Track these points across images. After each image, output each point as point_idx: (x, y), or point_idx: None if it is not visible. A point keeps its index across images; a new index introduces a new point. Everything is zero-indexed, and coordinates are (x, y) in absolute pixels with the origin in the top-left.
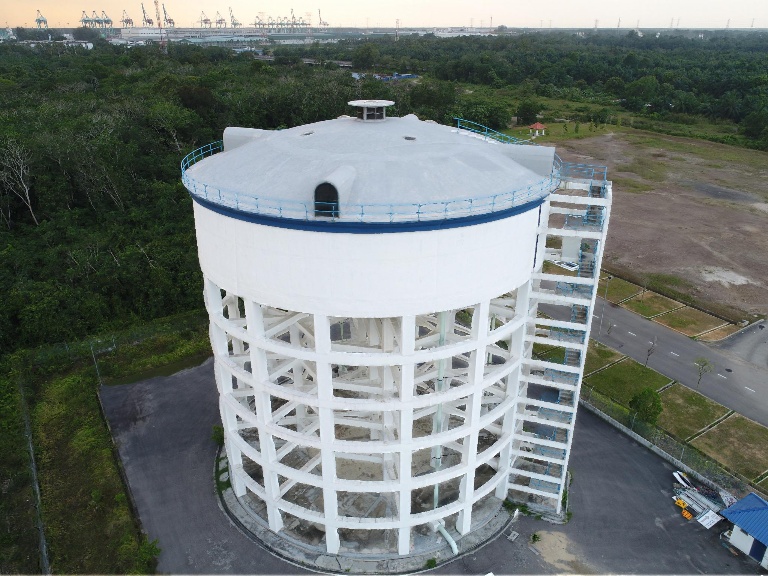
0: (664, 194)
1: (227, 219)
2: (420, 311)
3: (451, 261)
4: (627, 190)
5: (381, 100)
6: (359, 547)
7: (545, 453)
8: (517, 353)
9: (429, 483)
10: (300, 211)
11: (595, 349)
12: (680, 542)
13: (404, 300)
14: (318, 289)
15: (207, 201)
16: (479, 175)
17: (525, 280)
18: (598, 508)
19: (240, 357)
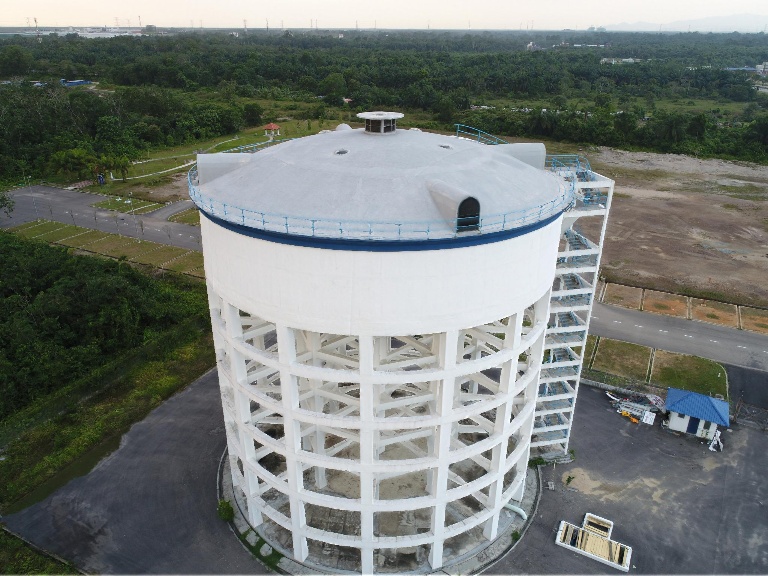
0: None
1: (341, 254)
2: (527, 304)
3: (545, 253)
4: None
5: None
6: (454, 551)
7: (555, 407)
8: None
9: None
10: (437, 230)
11: None
12: (646, 441)
13: (519, 297)
14: (454, 305)
15: (317, 238)
16: (525, 174)
17: None
18: (583, 439)
19: (266, 411)
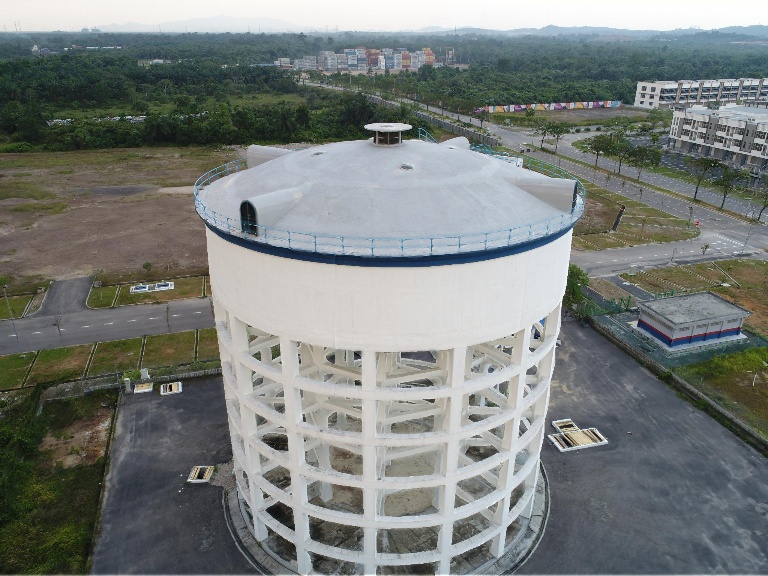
0: (86, 206)
1: (521, 256)
2: None
3: None
4: (49, 213)
5: None
6: None
7: None
8: None
9: None
10: None
11: None
12: None
13: None
14: None
15: (513, 246)
16: None
17: None
18: None
19: (376, 460)
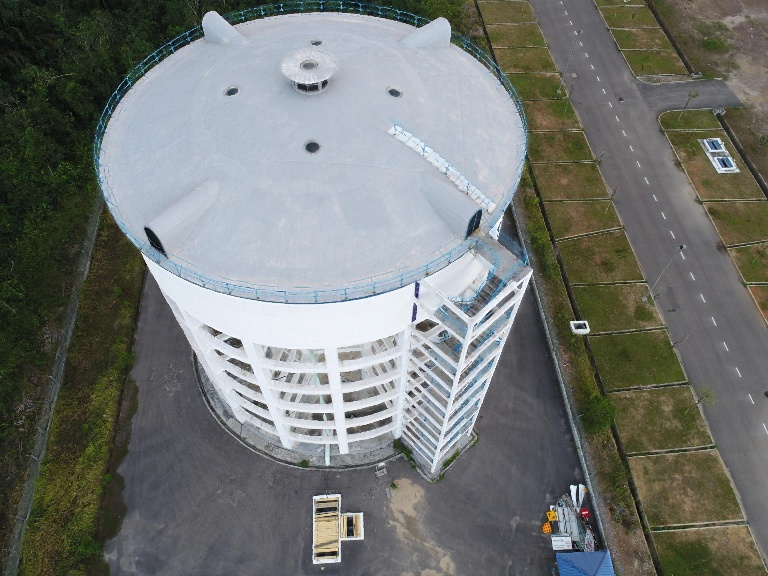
0: None
1: None
2: (256, 342)
3: (280, 320)
4: None
5: (329, 58)
6: None
7: None
8: (399, 368)
9: (298, 426)
10: None
11: (638, 303)
12: (516, 548)
13: (239, 331)
14: (172, 291)
15: None
16: (346, 235)
17: (395, 332)
18: (473, 483)
19: None
